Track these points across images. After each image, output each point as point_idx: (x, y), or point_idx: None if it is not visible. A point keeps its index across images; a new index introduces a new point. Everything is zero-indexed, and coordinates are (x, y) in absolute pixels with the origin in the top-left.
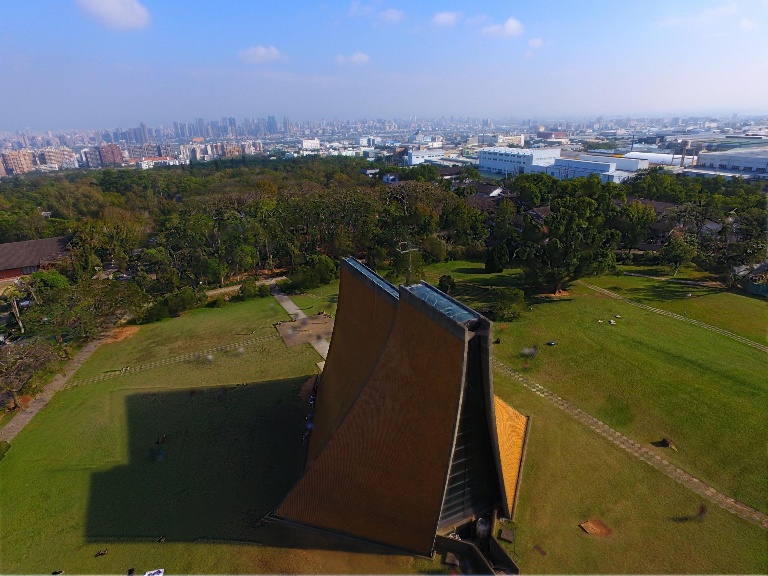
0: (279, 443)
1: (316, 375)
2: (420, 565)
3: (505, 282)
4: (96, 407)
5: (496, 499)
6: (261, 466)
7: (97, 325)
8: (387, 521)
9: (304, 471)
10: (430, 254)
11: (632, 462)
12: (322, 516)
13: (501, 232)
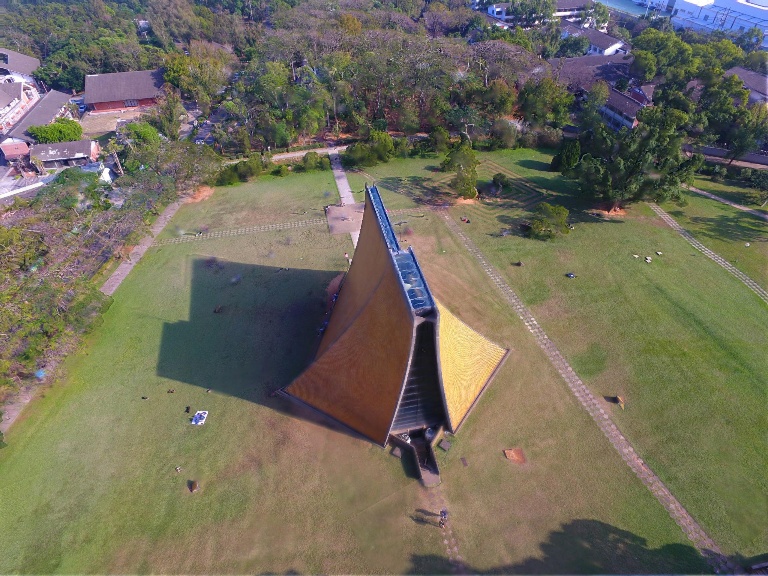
0: (301, 332)
1: (345, 272)
2: (374, 451)
3: (564, 187)
4: (175, 268)
5: (445, 418)
6: (284, 349)
7: (181, 181)
8: (357, 417)
9: (313, 360)
10: (497, 139)
11: (577, 410)
12: (316, 400)
13: (586, 119)
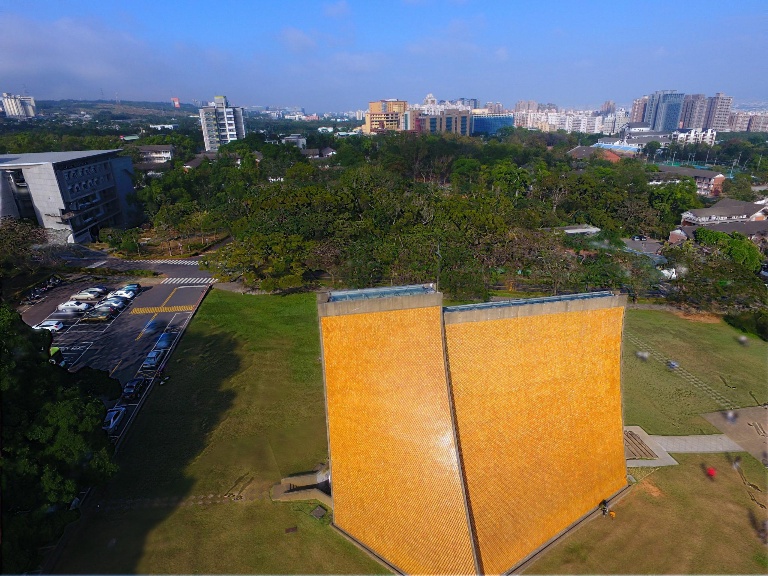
0: None
1: None
2: None
3: None
4: None
5: None
6: None
7: None
8: None
9: None
10: None
11: None
12: None
13: None
